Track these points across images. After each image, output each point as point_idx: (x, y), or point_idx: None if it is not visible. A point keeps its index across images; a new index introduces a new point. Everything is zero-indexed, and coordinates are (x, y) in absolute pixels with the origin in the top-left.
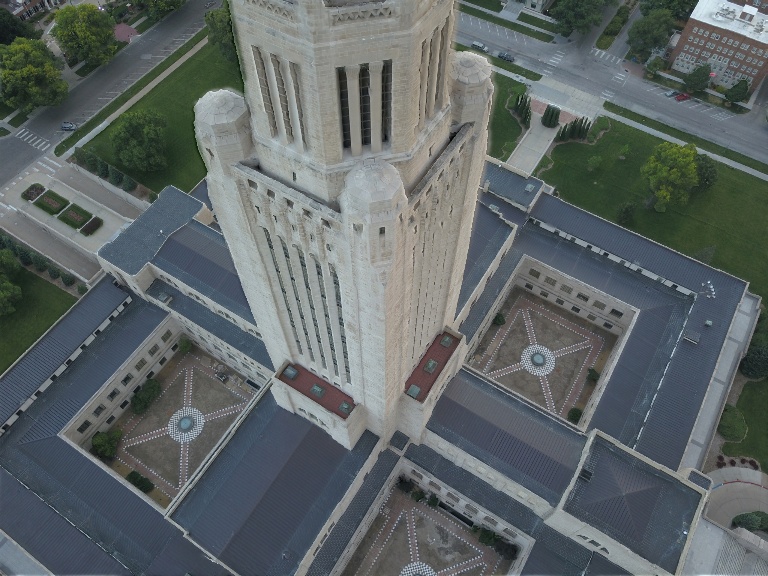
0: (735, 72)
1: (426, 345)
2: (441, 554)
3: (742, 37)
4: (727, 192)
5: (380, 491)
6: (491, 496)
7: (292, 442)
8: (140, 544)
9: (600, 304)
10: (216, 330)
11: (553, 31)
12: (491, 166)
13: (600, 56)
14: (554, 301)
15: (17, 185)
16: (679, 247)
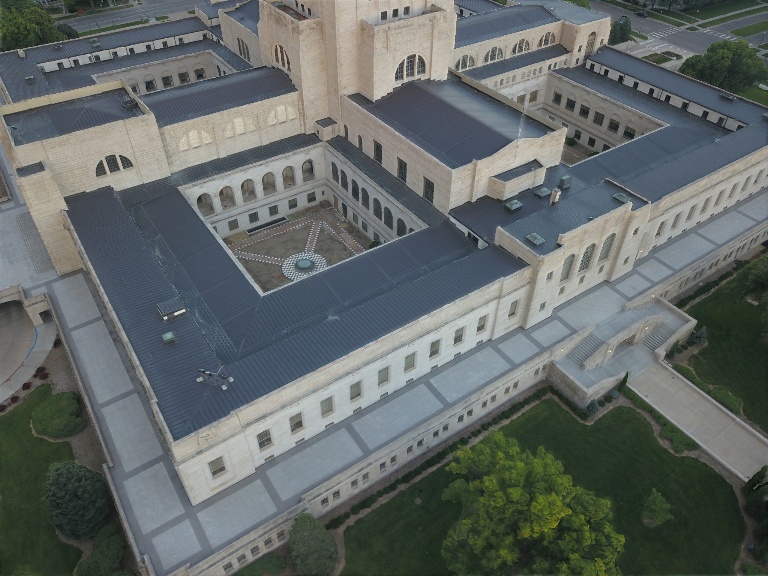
0: None
1: None
2: None
3: None
4: None
5: None
6: None
7: None
8: None
9: None
10: None
11: None
12: None
13: None
14: None
15: (682, 52)
16: (376, 567)
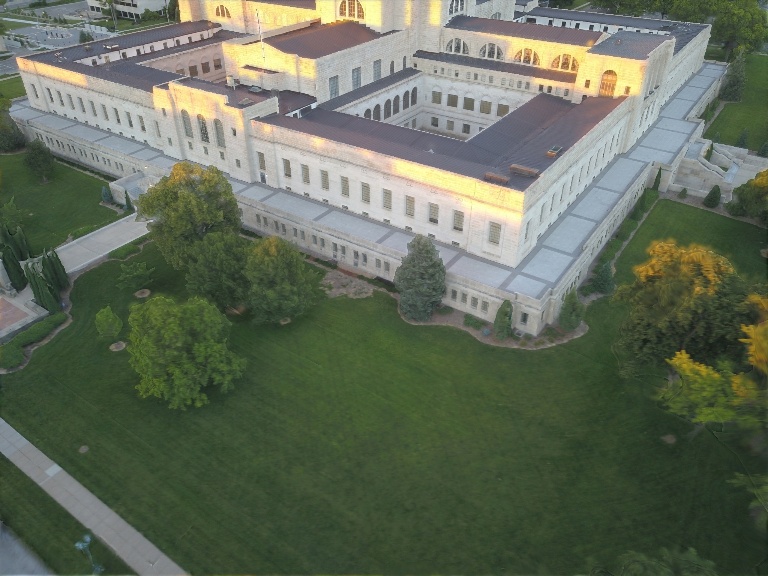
0: None
1: None
2: None
3: None
4: None
5: None
6: None
7: None
8: None
9: None
10: None
11: None
12: None
13: None
14: None
15: None
16: (5, 161)
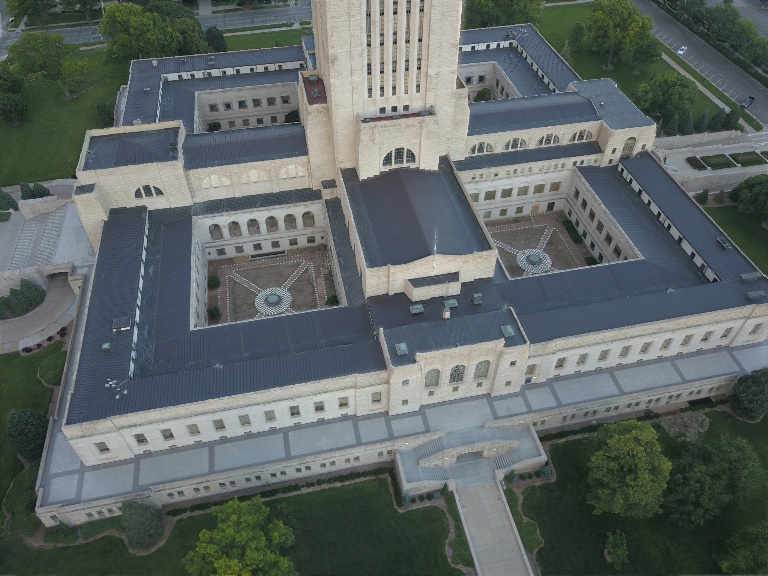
0: None
1: None
2: None
3: None
4: None
5: None
6: None
7: None
8: None
9: None
10: None
11: None
12: None
13: None
14: None
15: None
16: (182, 554)
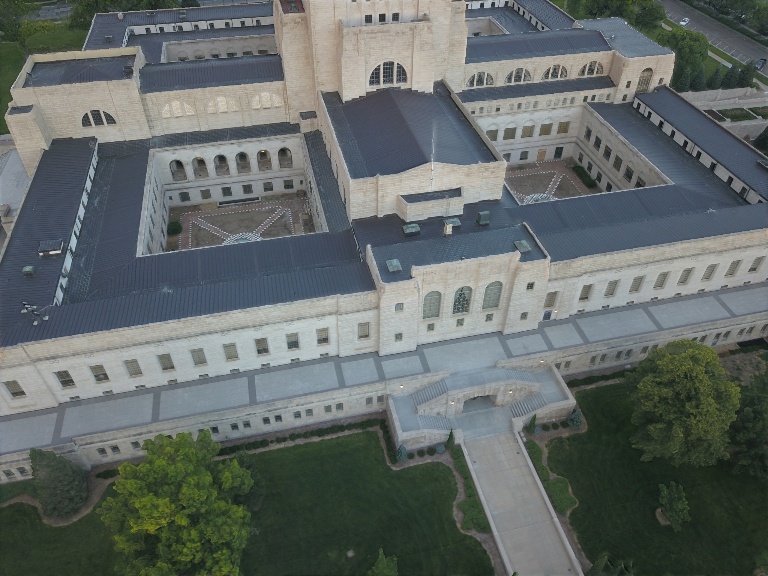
0: None
1: None
2: None
3: None
4: None
5: None
6: None
7: None
8: None
9: None
10: None
11: None
12: None
13: None
14: None
15: None
16: None
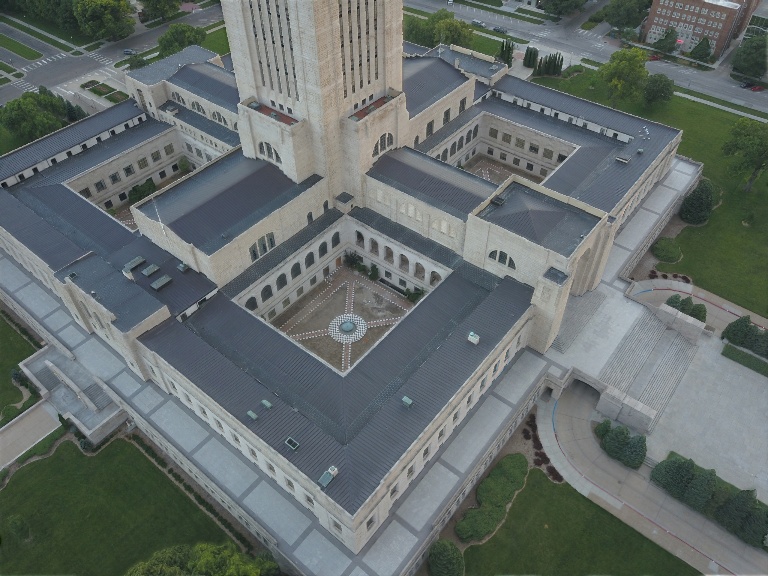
0: (700, 38)
1: (370, 96)
2: (374, 311)
3: (701, 3)
4: (686, 113)
5: (321, 232)
6: (419, 242)
7: (249, 171)
8: (107, 249)
9: (549, 152)
10: (208, 131)
11: (544, 18)
12: (464, 56)
13: (583, 33)
14: (512, 163)
15: (79, 81)
16: None
